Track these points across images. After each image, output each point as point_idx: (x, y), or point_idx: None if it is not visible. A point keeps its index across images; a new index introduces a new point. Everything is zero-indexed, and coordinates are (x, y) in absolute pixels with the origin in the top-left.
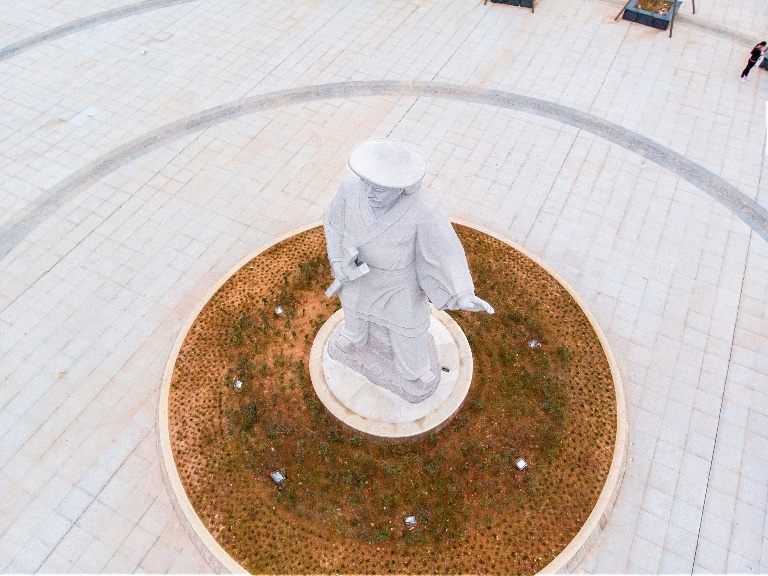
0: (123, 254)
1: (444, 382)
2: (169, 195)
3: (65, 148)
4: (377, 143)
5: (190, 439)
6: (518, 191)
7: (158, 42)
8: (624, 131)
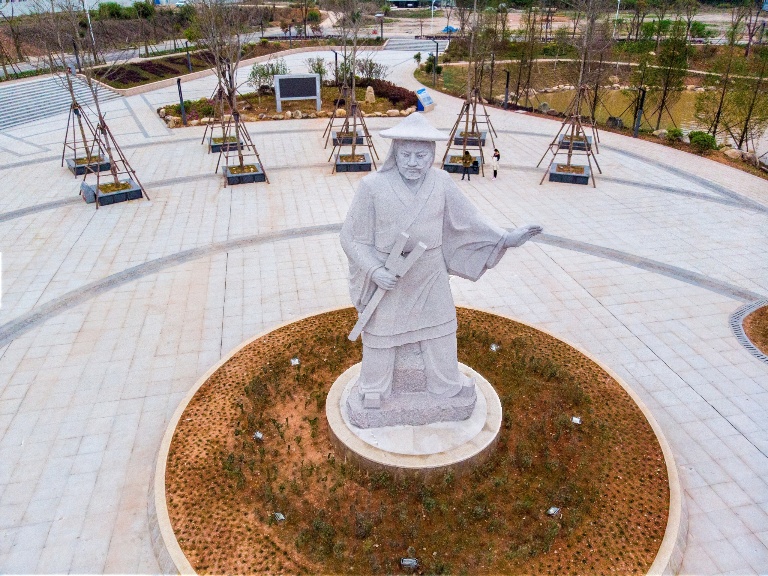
0: None
1: None
2: (8, 415)
3: None
4: None
5: None
6: None
7: None
8: None
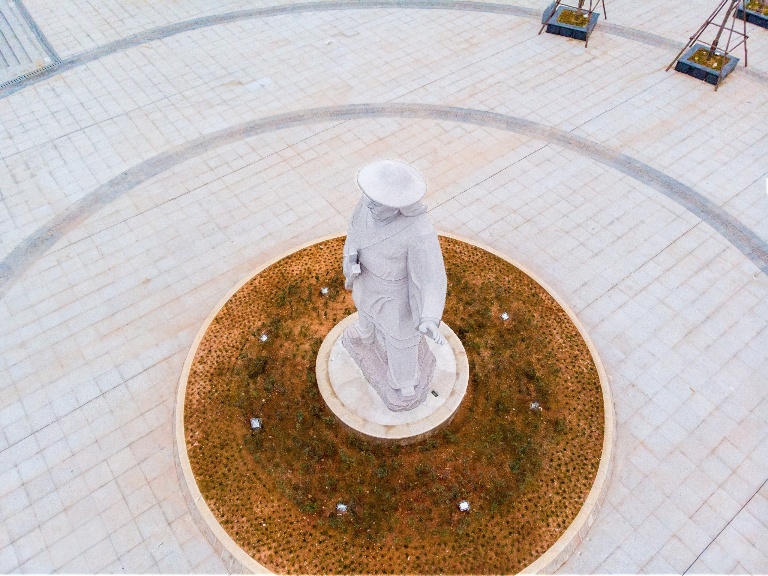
0: (233, 203)
1: (428, 403)
2: (290, 167)
3: (232, 106)
4: (391, 163)
5: (208, 366)
6: (602, 260)
7: (344, 37)
8: (752, 236)
